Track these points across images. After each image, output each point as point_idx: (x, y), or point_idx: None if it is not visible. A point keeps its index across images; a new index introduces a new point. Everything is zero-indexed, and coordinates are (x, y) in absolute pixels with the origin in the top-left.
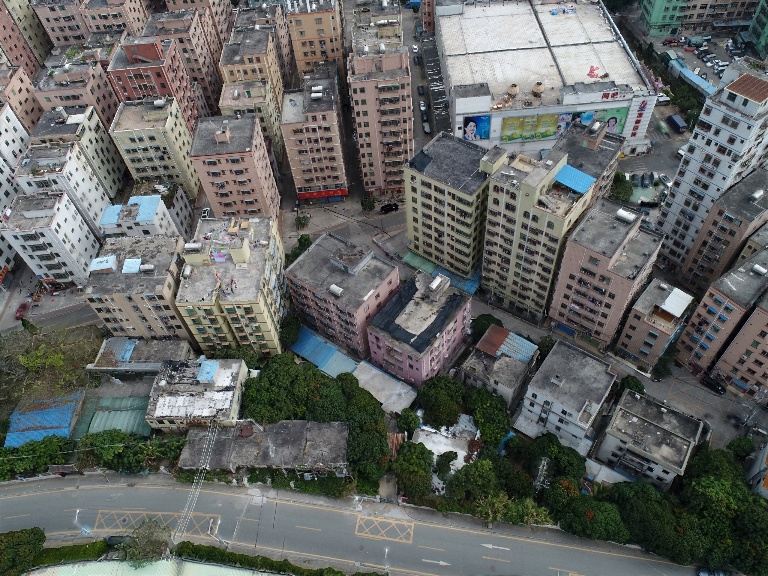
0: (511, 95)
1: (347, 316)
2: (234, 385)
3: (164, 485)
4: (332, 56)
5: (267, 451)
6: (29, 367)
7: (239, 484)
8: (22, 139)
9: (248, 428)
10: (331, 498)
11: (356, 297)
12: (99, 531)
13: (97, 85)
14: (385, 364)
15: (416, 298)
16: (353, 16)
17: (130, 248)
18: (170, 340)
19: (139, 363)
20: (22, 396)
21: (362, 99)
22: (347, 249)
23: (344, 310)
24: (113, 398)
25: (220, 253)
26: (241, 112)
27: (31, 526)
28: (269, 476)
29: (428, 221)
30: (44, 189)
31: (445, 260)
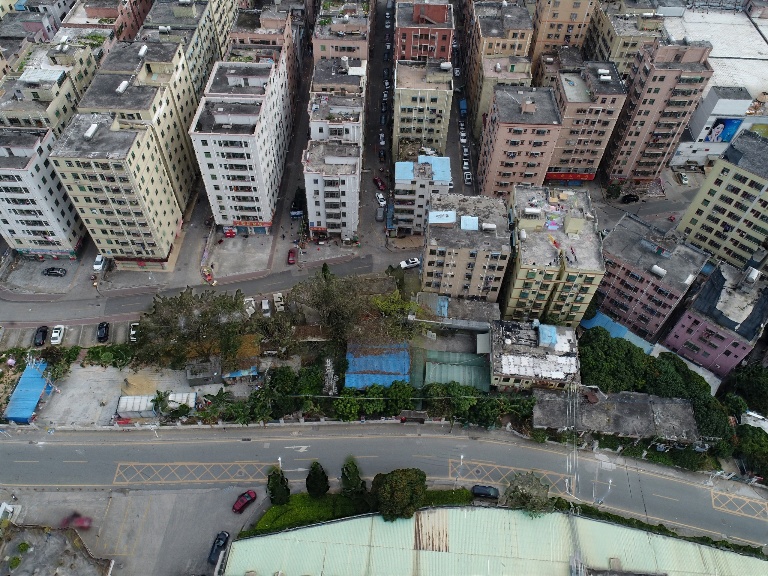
0: (760, 102)
1: (666, 297)
2: (576, 351)
3: (508, 441)
4: (573, 42)
5: (617, 419)
6: (386, 311)
7: (586, 448)
8: (285, 84)
9: (594, 395)
10: (680, 471)
11: (677, 280)
12: (455, 479)
13: (367, 40)
14: (683, 348)
15: (727, 288)
16: (599, 5)
17: (459, 205)
18: (482, 301)
19: (459, 320)
20: (347, 339)
21: (656, 87)
22: None
23: (666, 291)
24: (439, 351)
25: (553, 221)
26: (504, 85)
27: (384, 467)
28: (619, 443)
29: (718, 215)
30: (336, 137)
31: (716, 255)
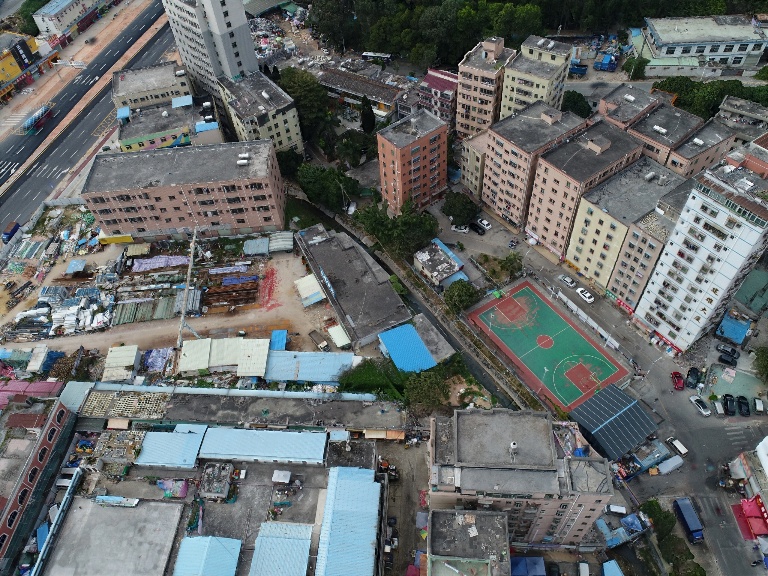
0: None
1: None
2: None
3: None
4: None
5: None
6: None
7: None
8: None
9: None
10: None
11: None
12: None
13: None
14: None
15: None
16: None
17: None
18: None
19: None
20: None
21: None
22: None
23: None
24: None
25: None
26: None
27: None
28: None
29: None
30: None
31: None
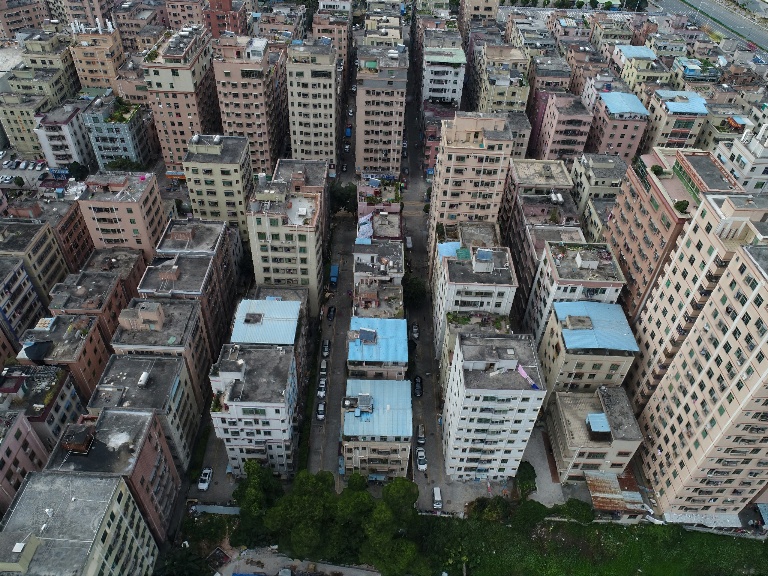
0: None
1: None
2: None
3: None
4: None
5: None
6: None
7: None
8: None
9: None
10: None
11: None
12: None
13: None
14: None
15: None
16: None
17: None
18: None
19: None
20: None
21: None
22: (150, 6)
23: None
24: None
25: None
26: None
27: None
28: None
29: None
30: None
31: None
